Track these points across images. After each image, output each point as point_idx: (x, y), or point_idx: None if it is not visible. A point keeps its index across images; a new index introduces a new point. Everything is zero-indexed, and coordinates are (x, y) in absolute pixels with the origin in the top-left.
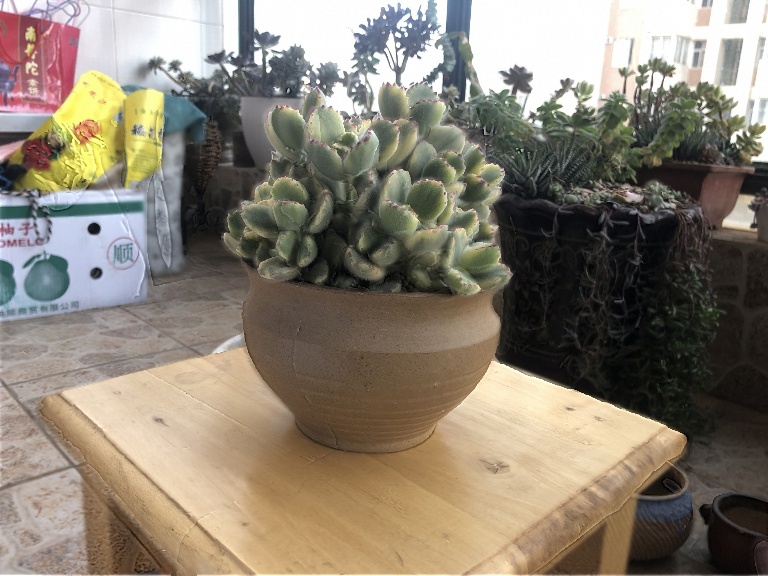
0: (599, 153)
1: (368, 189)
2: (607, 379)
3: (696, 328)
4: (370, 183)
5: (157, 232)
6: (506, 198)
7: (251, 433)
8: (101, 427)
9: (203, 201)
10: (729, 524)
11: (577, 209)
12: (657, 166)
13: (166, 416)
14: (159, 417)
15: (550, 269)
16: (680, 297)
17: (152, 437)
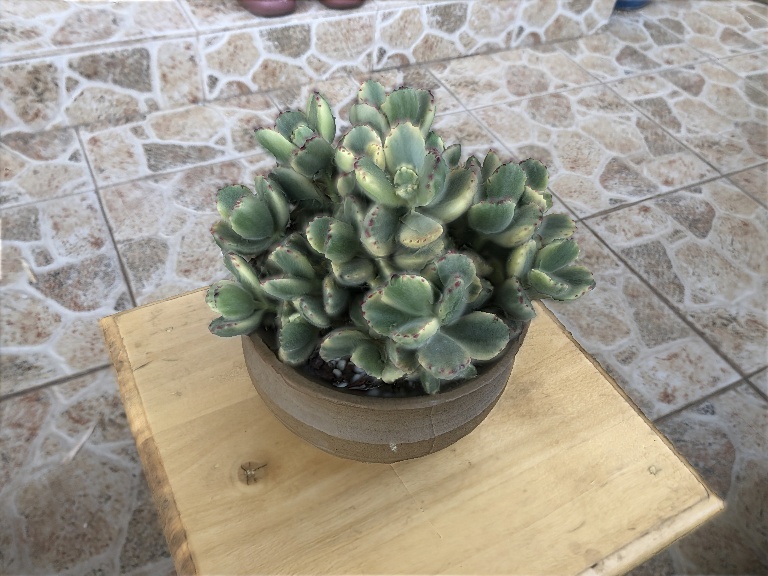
0: None
1: None
2: None
3: None
4: None
5: None
6: None
7: None
8: None
9: None
10: None
11: None
12: None
13: None
14: None
15: None
16: None
17: None
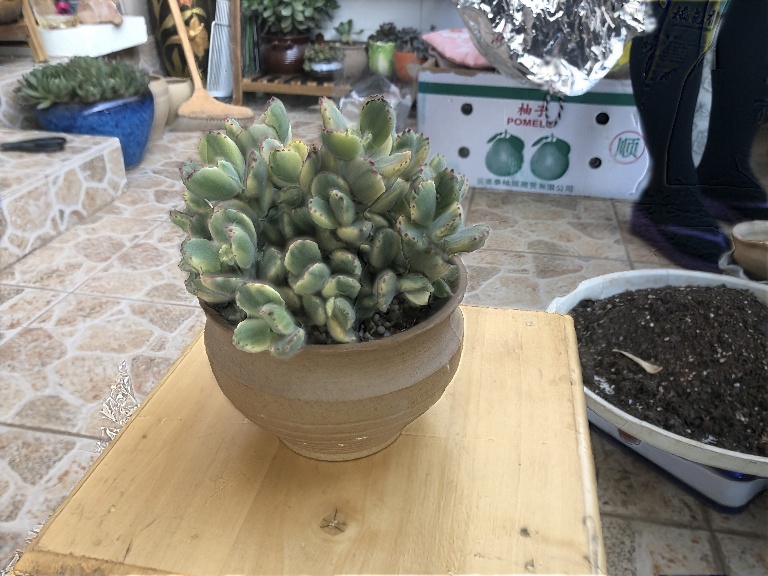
0: None
1: (209, 220)
2: None
3: None
4: None
5: (693, 127)
6: None
7: None
8: None
9: None
10: None
11: None
12: None
13: None
14: None
15: None
16: None
17: None
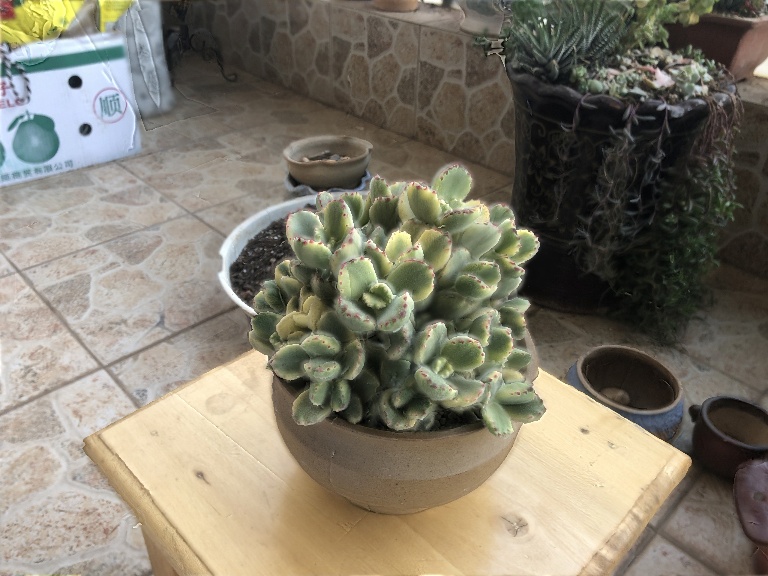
0: (631, 17)
1: (403, 349)
2: (614, 269)
3: (710, 220)
4: (405, 342)
5: (141, 69)
6: (524, 80)
7: (288, 489)
8: (147, 488)
9: (186, 23)
10: (714, 432)
11: (601, 102)
12: (693, 24)
13: (206, 468)
14: (199, 470)
15: (567, 163)
16: (698, 191)
17: (197, 502)
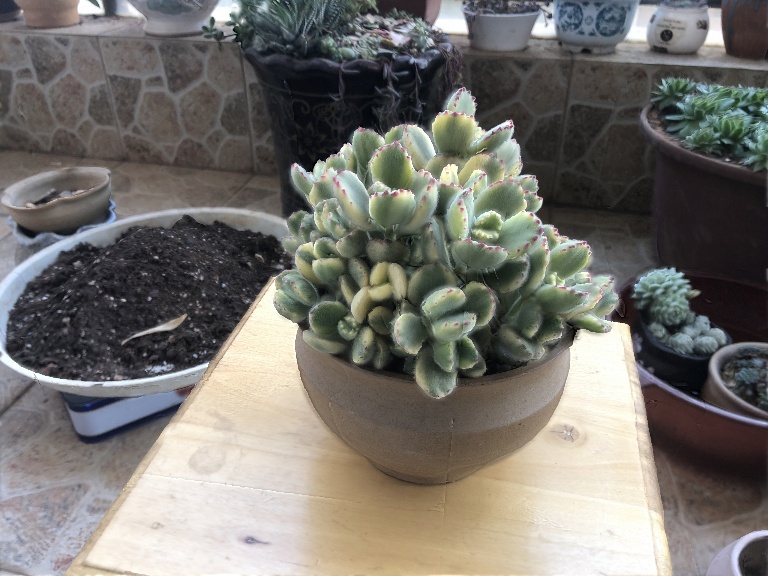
0: None
1: (525, 273)
2: None
3: None
4: (525, 265)
5: None
6: (276, 60)
7: (354, 505)
8: None
9: None
10: None
11: (360, 66)
12: None
13: (251, 530)
14: (244, 536)
15: (342, 132)
16: None
17: (271, 568)
